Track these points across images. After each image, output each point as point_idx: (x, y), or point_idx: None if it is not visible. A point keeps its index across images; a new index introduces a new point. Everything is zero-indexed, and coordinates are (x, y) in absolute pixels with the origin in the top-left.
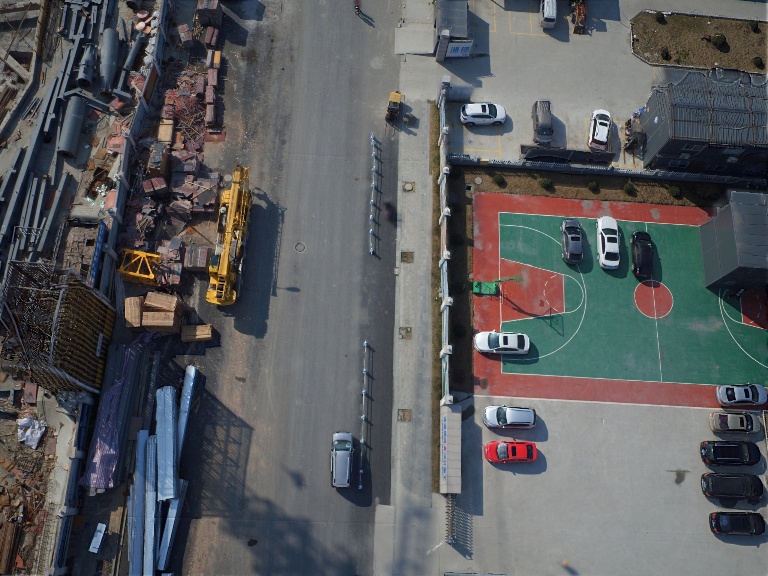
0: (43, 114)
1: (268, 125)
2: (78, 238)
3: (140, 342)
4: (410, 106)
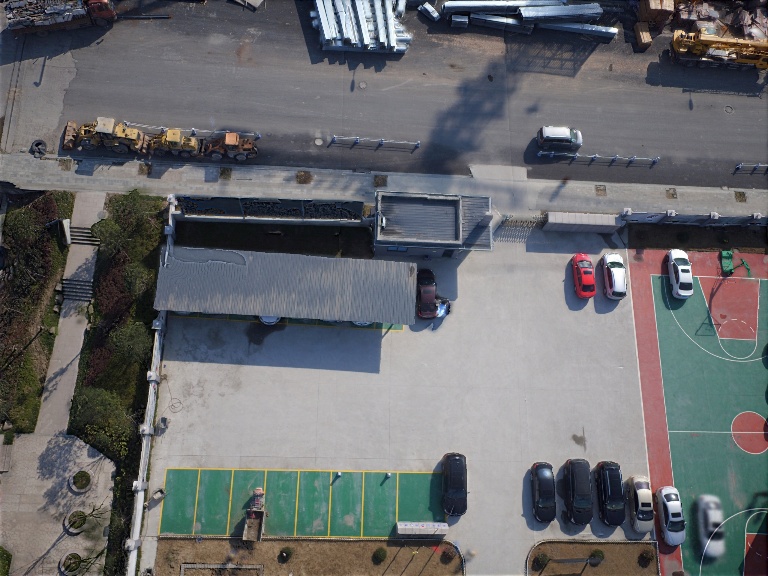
0: None
1: None
2: None
3: None
4: None
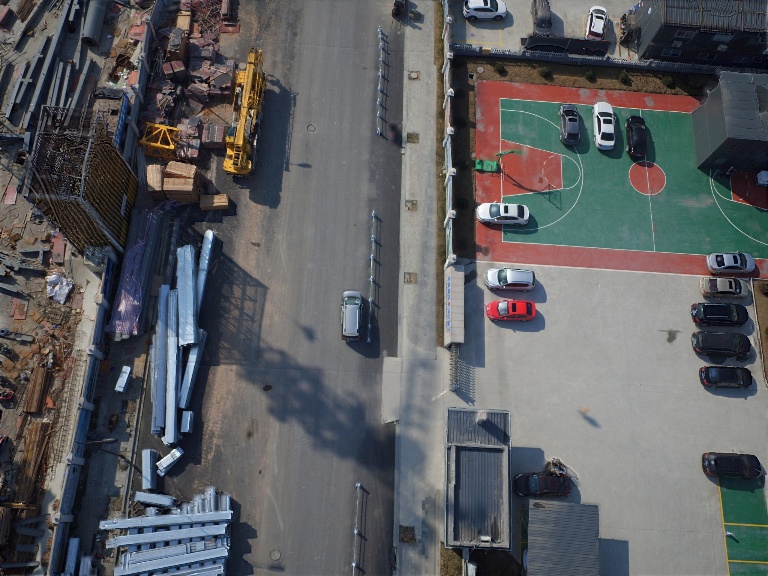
0: (68, 5)
1: (280, 19)
2: (103, 108)
3: (161, 209)
4: (415, 3)
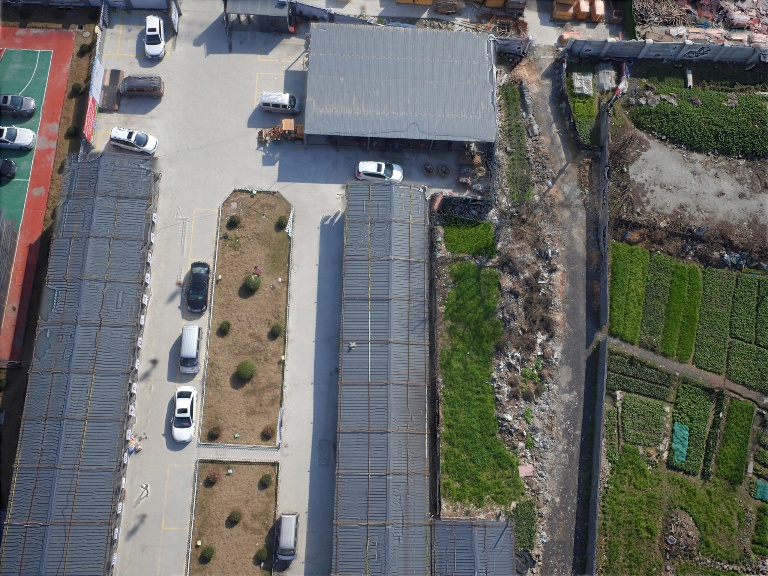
0: None
1: None
2: None
3: None
4: None
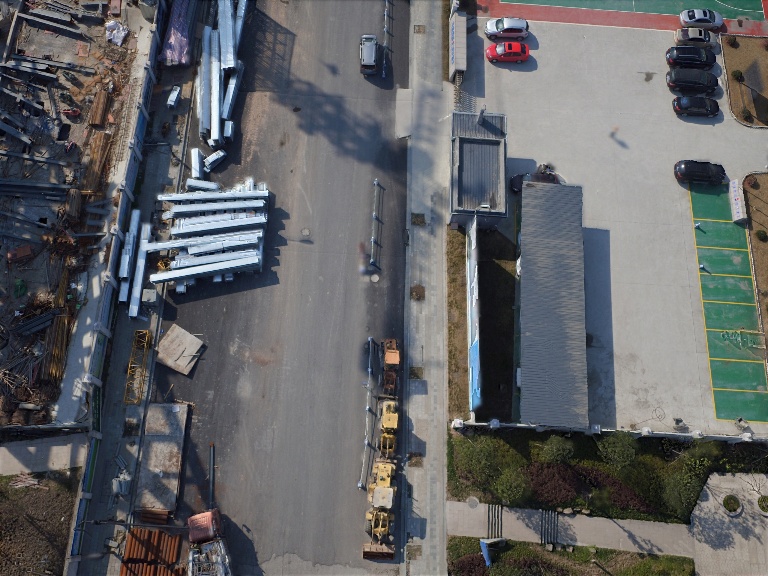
0: None
1: None
2: None
3: None
4: None
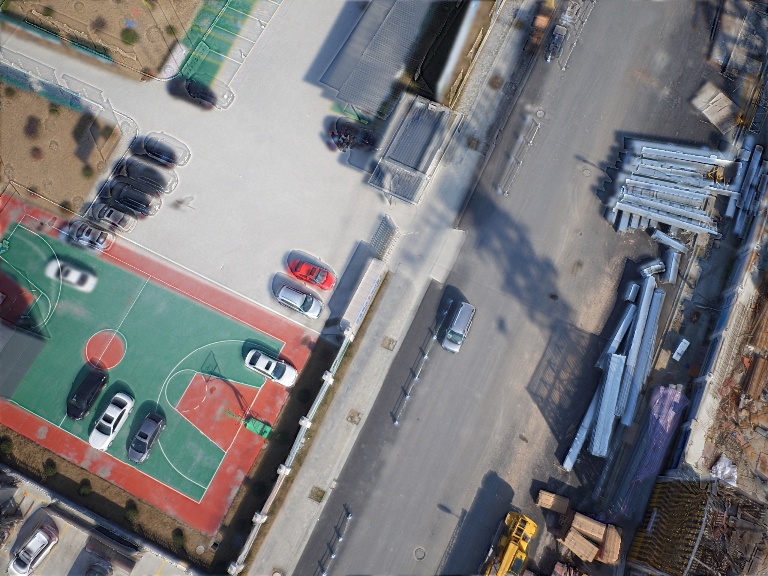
0: None
1: None
2: None
3: (609, 515)
4: None
